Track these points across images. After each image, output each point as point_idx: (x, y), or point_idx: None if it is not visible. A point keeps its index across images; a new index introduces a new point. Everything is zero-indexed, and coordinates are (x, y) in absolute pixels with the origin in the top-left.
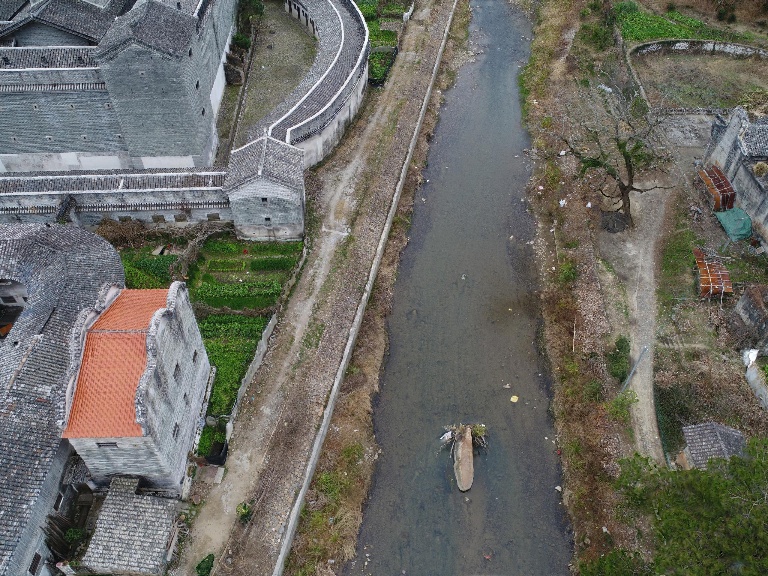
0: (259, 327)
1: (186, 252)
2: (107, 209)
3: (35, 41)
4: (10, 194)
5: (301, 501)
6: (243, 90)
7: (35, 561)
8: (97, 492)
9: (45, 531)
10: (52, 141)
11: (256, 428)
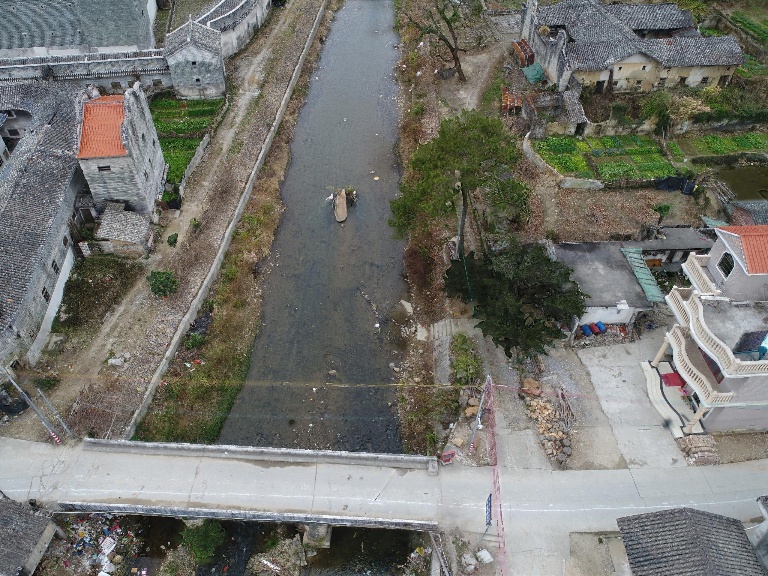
0: (197, 143)
1: None
2: (77, 77)
3: None
4: (3, 67)
5: (233, 227)
6: (172, 13)
7: (65, 240)
8: (97, 219)
9: (69, 226)
10: (27, 37)
11: (199, 192)
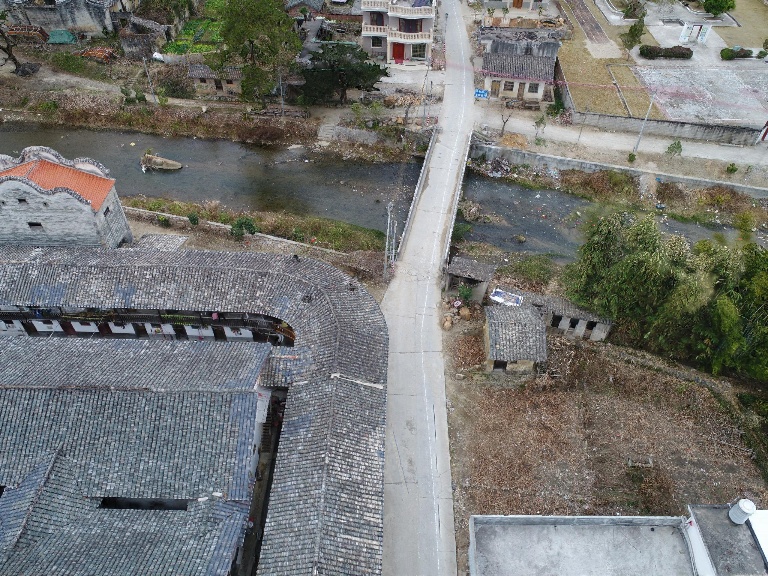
0: None
1: None
2: None
3: None
4: None
5: None
6: None
7: None
8: None
9: None
10: None
11: None
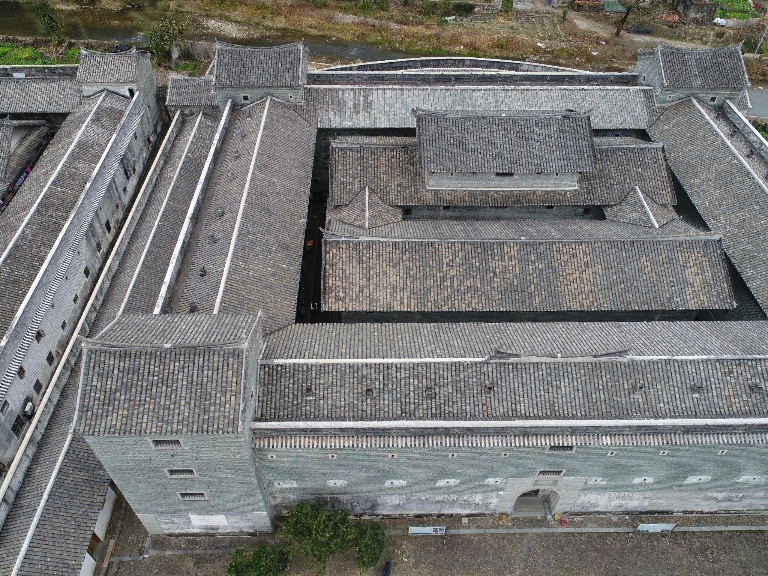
0: None
1: None
2: None
3: None
4: None
5: None
6: None
7: None
8: None
9: None
10: None
11: None
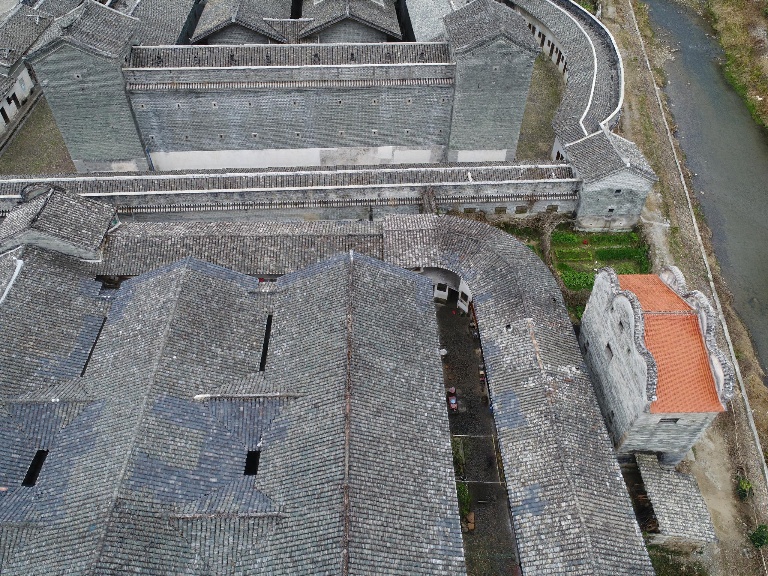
0: None
1: None
2: (461, 201)
3: (336, 38)
4: (375, 186)
5: None
6: None
7: None
8: None
9: None
10: (375, 135)
11: None
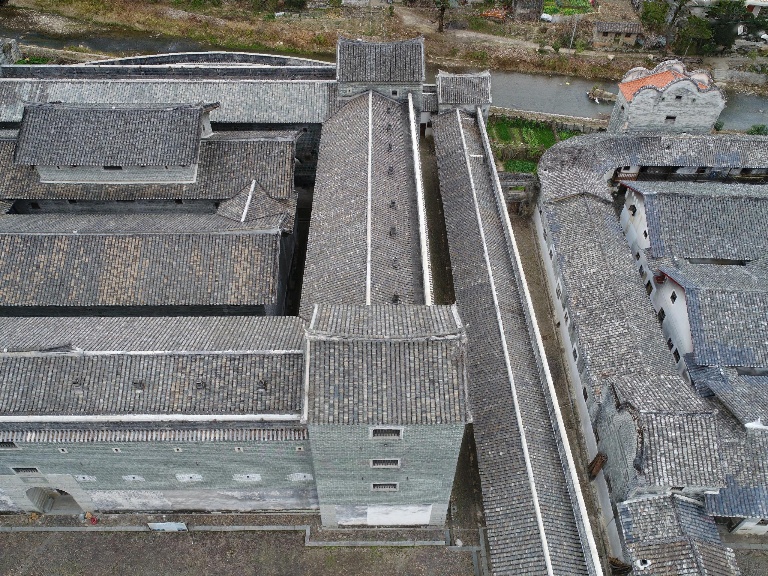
0: (564, 133)
1: (519, 147)
2: None
3: None
4: None
5: None
6: None
7: None
8: None
9: None
10: None
11: None
